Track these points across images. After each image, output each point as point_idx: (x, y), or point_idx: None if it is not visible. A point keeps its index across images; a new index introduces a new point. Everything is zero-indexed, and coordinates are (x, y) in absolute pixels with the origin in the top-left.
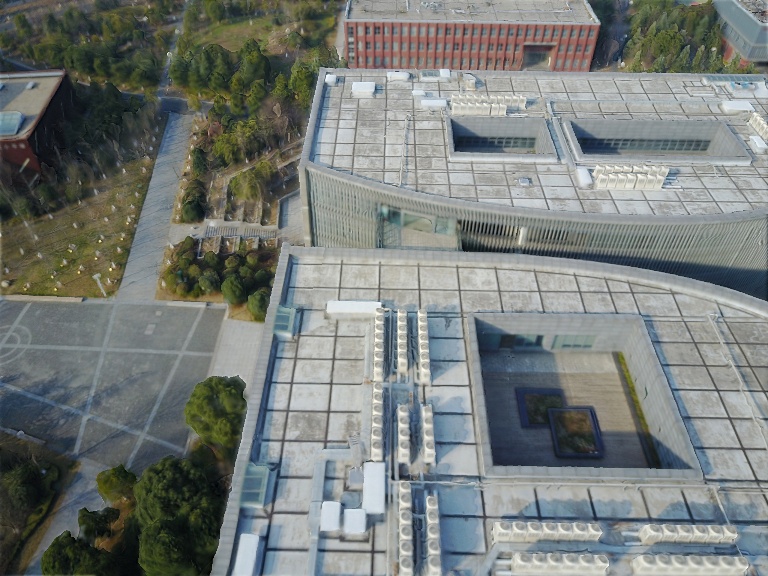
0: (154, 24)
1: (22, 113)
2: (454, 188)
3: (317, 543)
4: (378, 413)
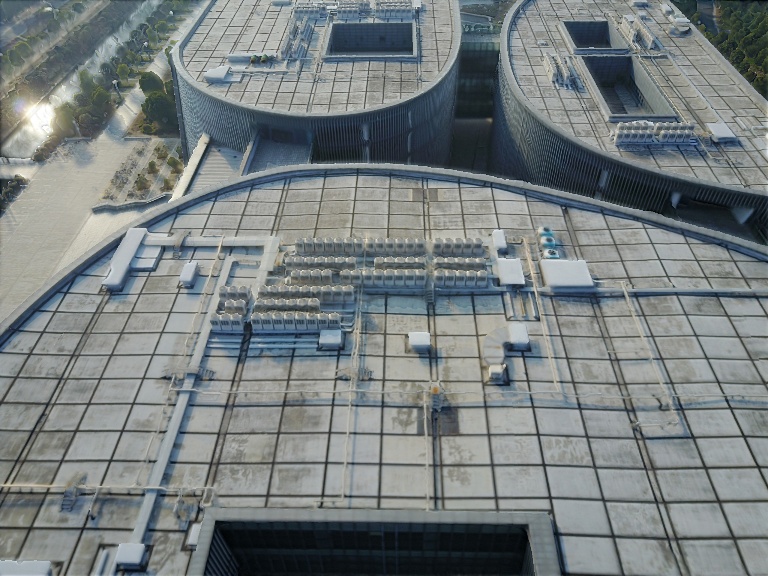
0: None
1: None
2: None
3: (310, 3)
4: (355, 1)
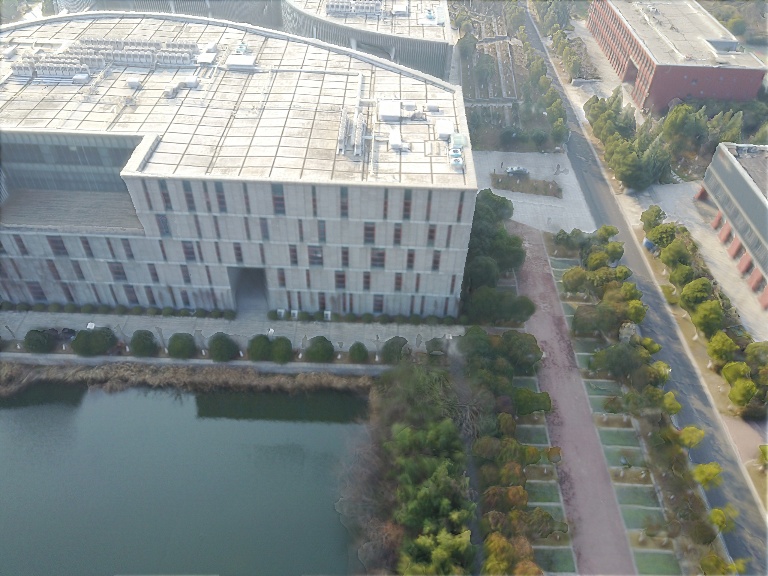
0: None
1: None
2: None
3: None
4: None
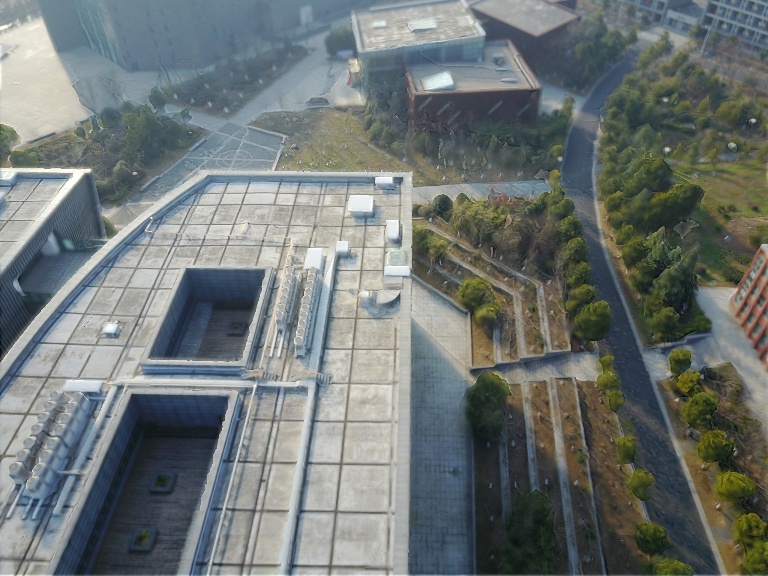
0: (762, 133)
1: (459, 86)
2: (128, 271)
3: None
4: None
